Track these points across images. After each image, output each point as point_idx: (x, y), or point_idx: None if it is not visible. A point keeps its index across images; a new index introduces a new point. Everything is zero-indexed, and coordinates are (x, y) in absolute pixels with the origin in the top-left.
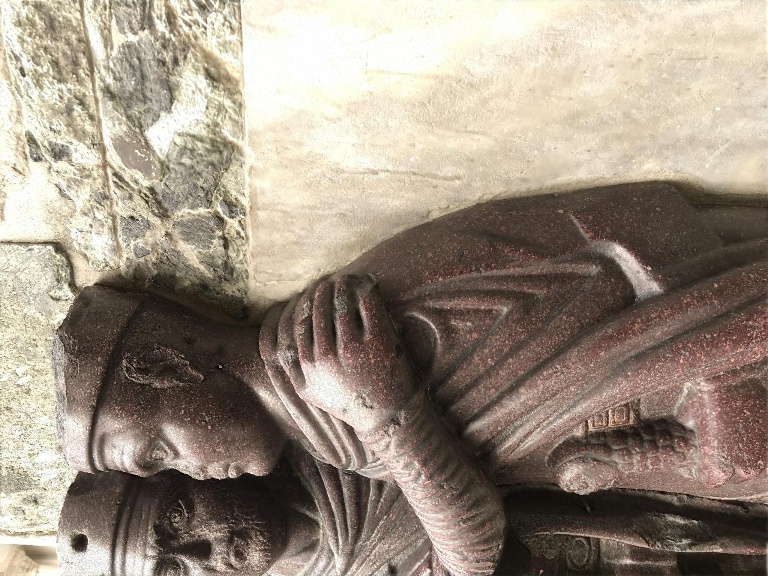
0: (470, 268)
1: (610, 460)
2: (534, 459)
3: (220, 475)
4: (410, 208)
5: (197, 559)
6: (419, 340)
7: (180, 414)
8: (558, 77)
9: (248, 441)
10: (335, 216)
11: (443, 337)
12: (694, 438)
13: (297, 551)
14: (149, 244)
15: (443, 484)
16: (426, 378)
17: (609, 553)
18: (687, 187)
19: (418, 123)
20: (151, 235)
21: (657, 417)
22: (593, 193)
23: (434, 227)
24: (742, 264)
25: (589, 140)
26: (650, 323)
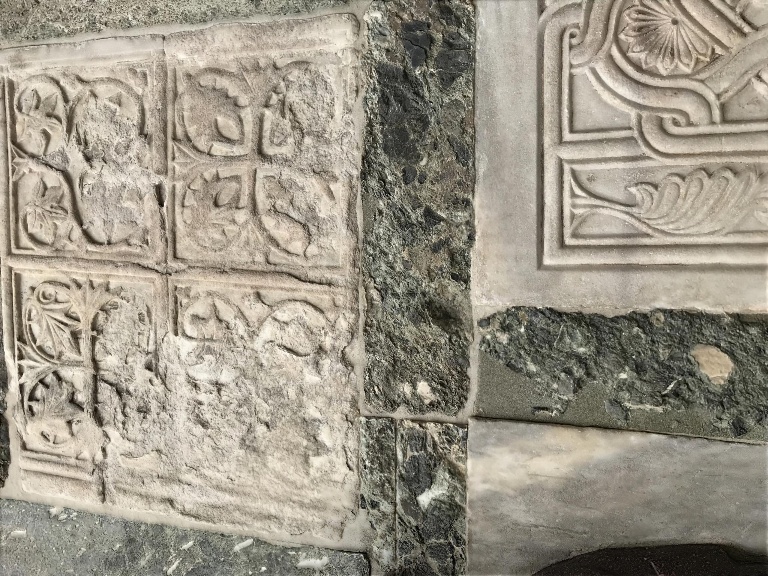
0: None
1: None
2: None
3: None
4: (558, 549)
5: None
6: None
7: None
8: (634, 482)
9: None
10: (515, 550)
11: None
12: None
13: None
14: (412, 558)
15: None
16: None
17: None
18: (733, 549)
19: (559, 502)
20: (414, 553)
21: None
22: (668, 549)
23: (571, 562)
24: None
25: (661, 516)
26: None
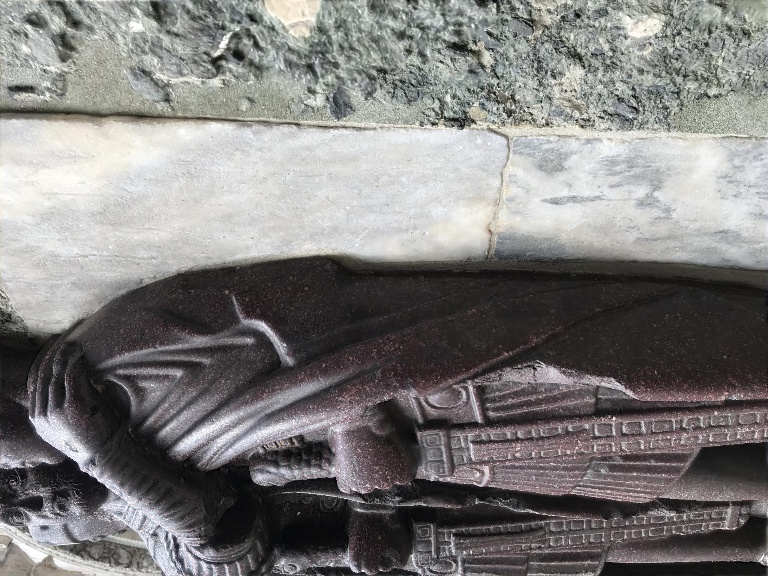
0: (148, 345)
1: (278, 472)
2: (242, 461)
3: None
4: (125, 278)
5: (32, 510)
6: (119, 396)
7: None
8: (202, 192)
9: (31, 448)
10: (67, 284)
11: (133, 396)
12: None
13: (117, 497)
14: None
15: (141, 497)
16: (126, 423)
17: (350, 501)
18: (347, 259)
19: (103, 224)
20: None
21: (317, 441)
22: (262, 270)
23: (137, 299)
24: (357, 342)
25: (249, 231)
26: (274, 393)
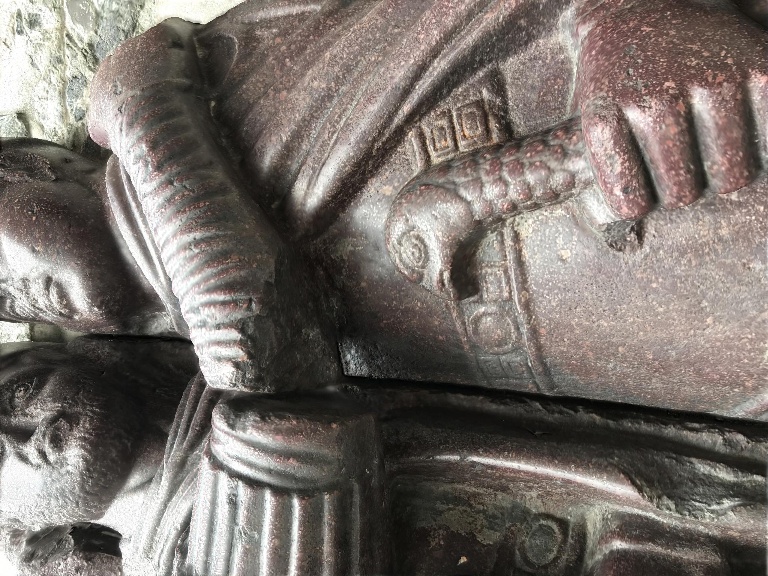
0: None
1: (446, 181)
2: (376, 245)
3: (41, 294)
4: None
5: (15, 440)
6: (221, 61)
7: (13, 202)
8: None
9: (71, 245)
10: None
11: (241, 45)
12: (580, 119)
13: (143, 481)
14: (85, 104)
15: (173, 179)
16: (212, 91)
17: (593, 544)
18: None
19: None
20: None
21: (541, 130)
22: None
23: None
24: None
25: None
26: None
